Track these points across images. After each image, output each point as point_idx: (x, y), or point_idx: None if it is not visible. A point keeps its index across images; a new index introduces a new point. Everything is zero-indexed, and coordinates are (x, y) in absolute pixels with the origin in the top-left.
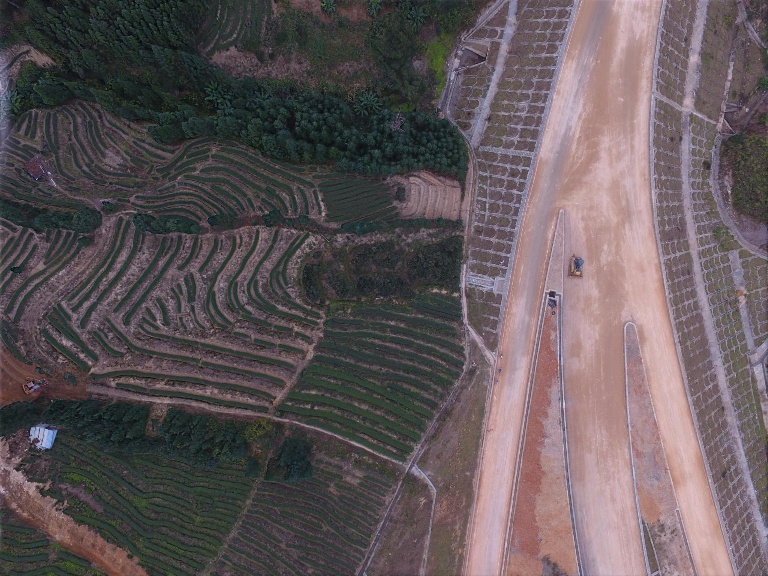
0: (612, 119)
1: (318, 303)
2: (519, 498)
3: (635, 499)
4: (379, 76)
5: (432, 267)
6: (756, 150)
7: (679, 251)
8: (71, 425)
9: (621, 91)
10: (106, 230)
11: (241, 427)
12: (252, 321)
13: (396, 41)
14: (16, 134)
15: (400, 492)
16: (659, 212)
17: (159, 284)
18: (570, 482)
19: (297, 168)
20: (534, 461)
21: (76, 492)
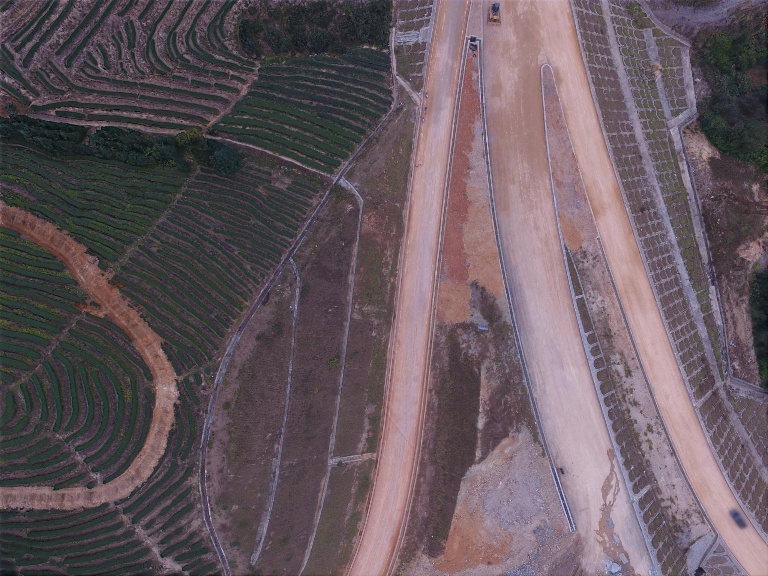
0: None
1: (254, 57)
2: (447, 228)
3: (557, 226)
4: None
5: (362, 25)
6: None
7: (592, 10)
8: (7, 124)
9: None
10: None
11: None
12: (190, 69)
13: None
14: None
15: (328, 199)
16: None
17: (100, 29)
18: (495, 211)
19: None
20: (460, 192)
21: (10, 188)
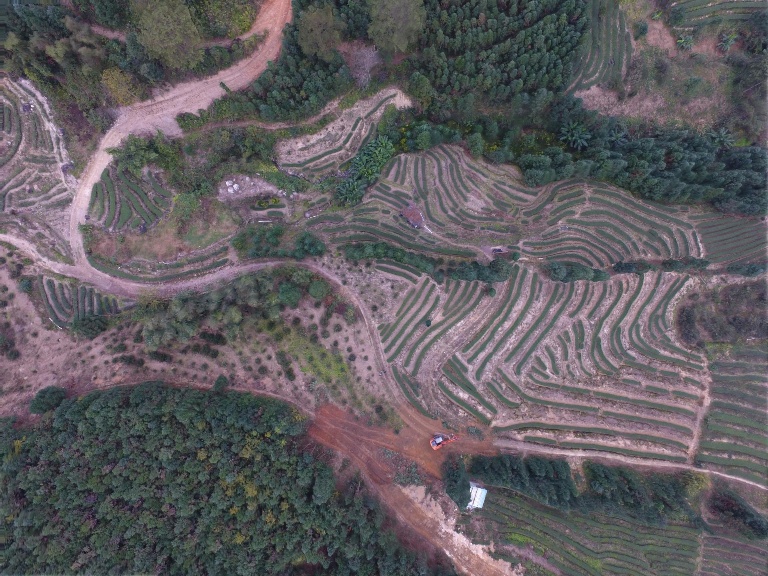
0: None
1: (693, 346)
2: None
3: None
4: (726, 111)
5: None
6: None
7: None
8: (519, 485)
9: None
10: None
11: (668, 480)
12: (634, 366)
13: None
14: (385, 180)
15: None
16: None
17: (549, 332)
18: None
19: (670, 209)
20: None
21: (525, 554)
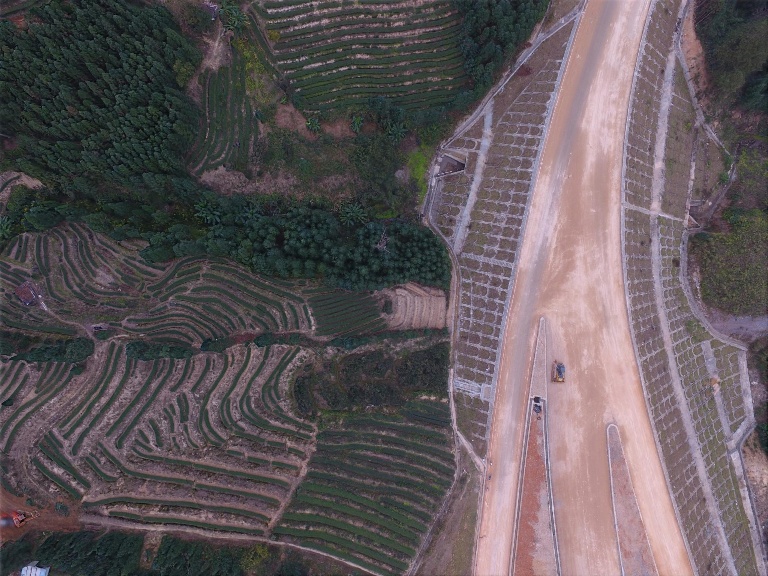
0: (585, 229)
1: (310, 415)
2: None
3: None
4: (363, 187)
5: (420, 374)
6: (720, 248)
7: (655, 350)
8: (65, 566)
9: (593, 203)
10: (98, 356)
11: (237, 554)
12: (245, 437)
13: (379, 164)
14: (6, 258)
15: None
16: (634, 316)
17: (152, 406)
18: None
19: (286, 283)
20: (527, 566)
21: None
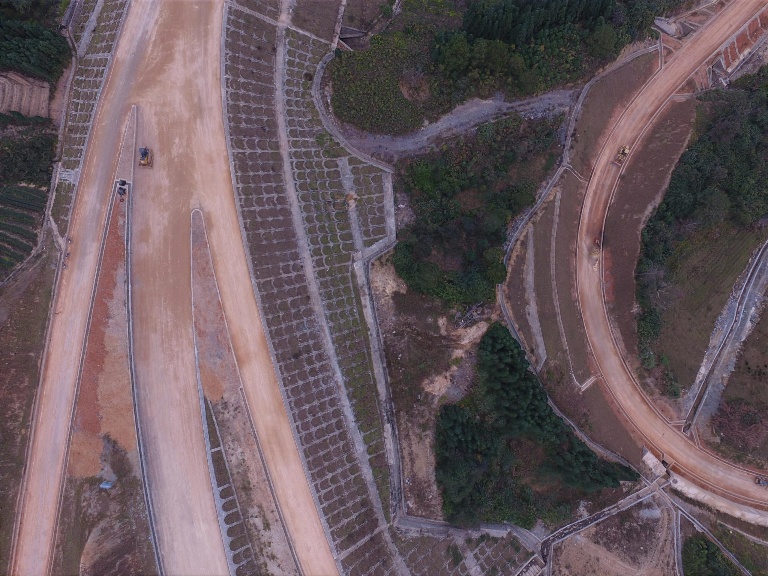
0: (187, 24)
1: None
2: (83, 378)
3: (197, 377)
4: None
5: (20, 162)
6: (351, 63)
7: (261, 148)
8: None
9: None
10: None
11: None
12: None
13: None
14: None
15: None
16: (231, 109)
17: None
18: (132, 361)
19: None
20: (98, 341)
21: None
